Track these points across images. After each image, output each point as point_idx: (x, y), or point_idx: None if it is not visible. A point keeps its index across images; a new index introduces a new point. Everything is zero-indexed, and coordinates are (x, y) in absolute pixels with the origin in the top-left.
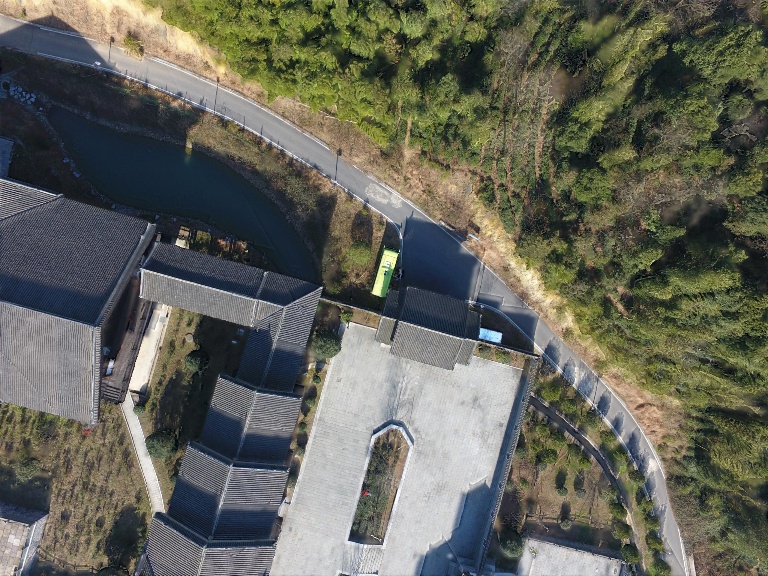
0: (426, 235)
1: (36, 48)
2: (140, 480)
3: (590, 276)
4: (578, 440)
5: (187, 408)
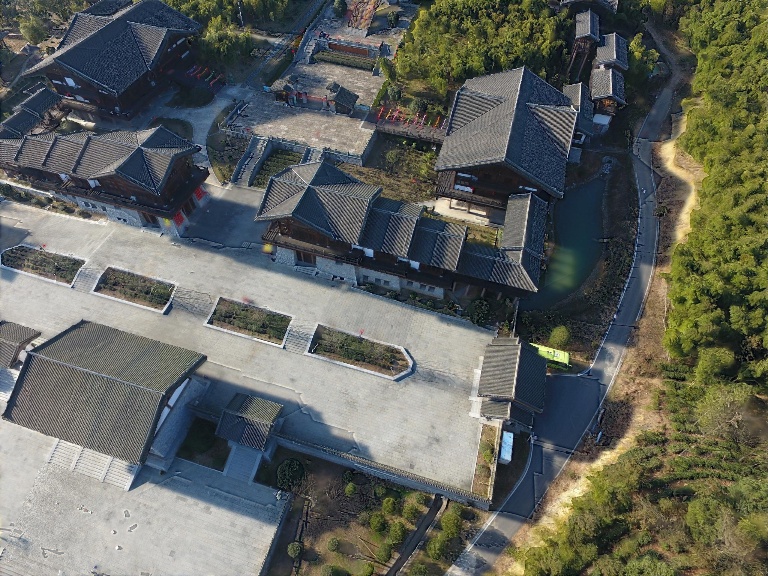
0: (587, 396)
1: (639, 172)
2: None
3: (601, 547)
4: (387, 575)
5: None
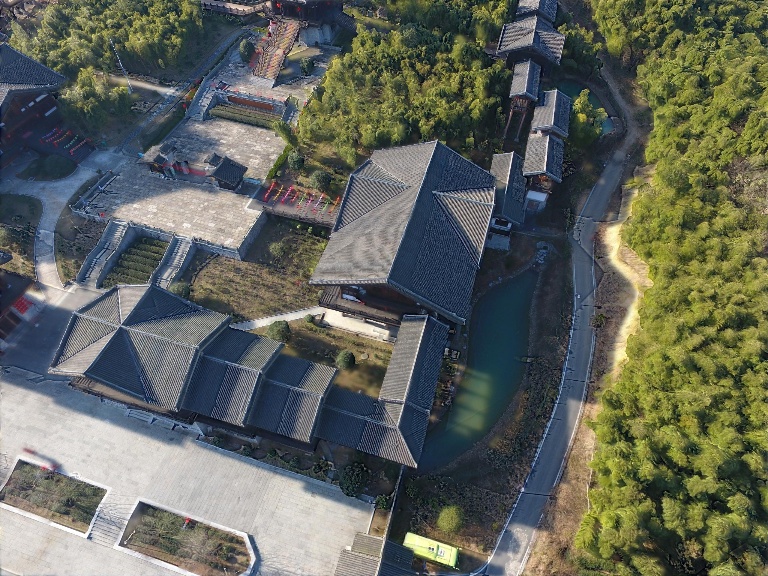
0: None
1: (577, 263)
2: (251, 318)
3: None
4: None
5: (305, 353)
